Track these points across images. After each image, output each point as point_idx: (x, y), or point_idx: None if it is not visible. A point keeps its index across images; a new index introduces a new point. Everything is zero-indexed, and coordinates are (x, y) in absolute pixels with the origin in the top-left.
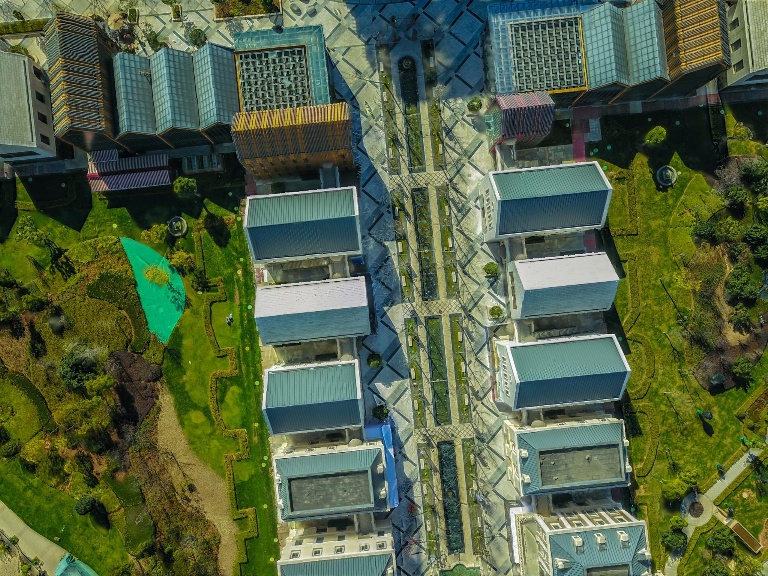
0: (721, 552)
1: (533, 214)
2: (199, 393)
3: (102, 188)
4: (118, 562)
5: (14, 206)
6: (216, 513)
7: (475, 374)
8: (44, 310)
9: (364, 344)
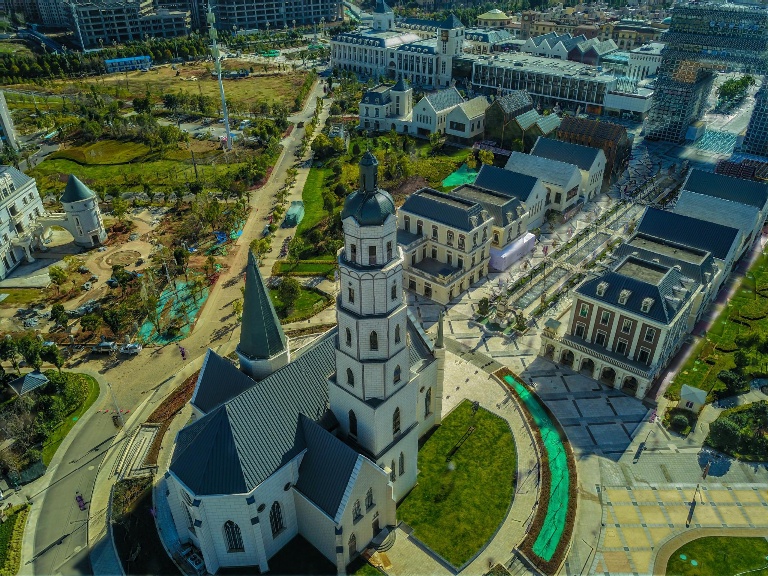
0: None
1: (712, 186)
2: None
3: None
4: (320, 216)
5: None
6: None
7: None
8: None
9: None
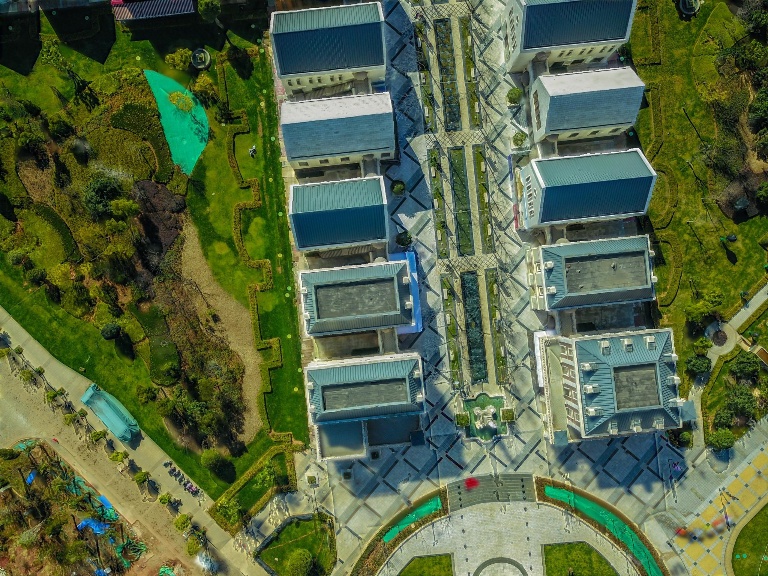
0: (745, 377)
1: (558, 24)
2: (223, 224)
3: (126, 16)
4: None
5: (38, 38)
6: (240, 343)
7: (498, 205)
8: (68, 141)
9: (387, 175)
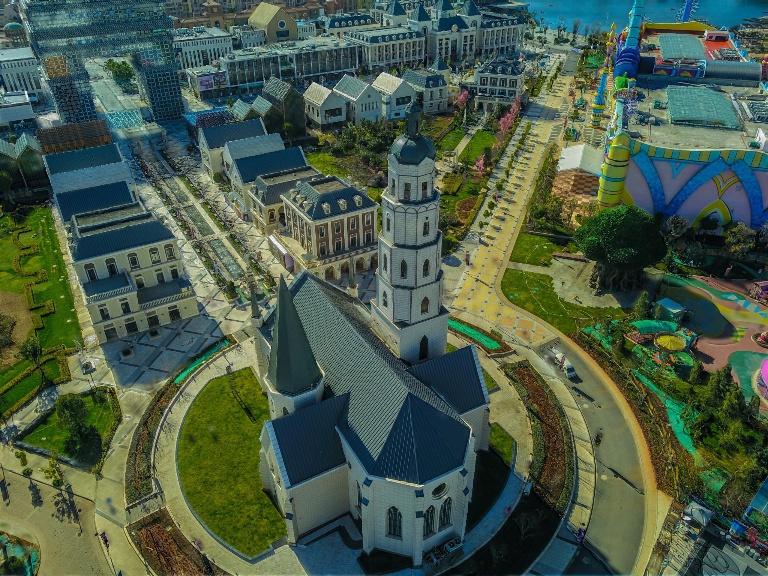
0: None
1: (224, 135)
2: (4, 265)
3: None
4: None
5: None
6: (13, 311)
7: None
8: None
9: None
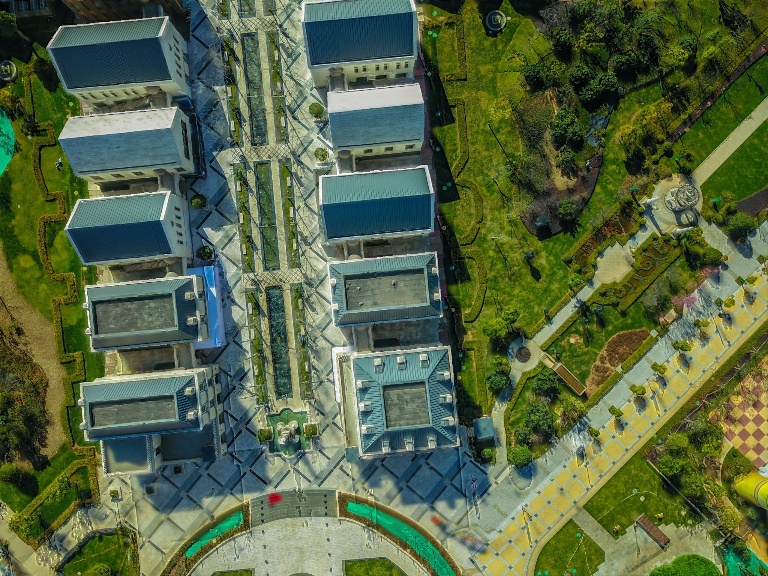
0: (544, 394)
1: (341, 40)
2: (28, 237)
3: None
4: None
5: None
6: (44, 357)
7: (304, 219)
8: None
9: (193, 189)
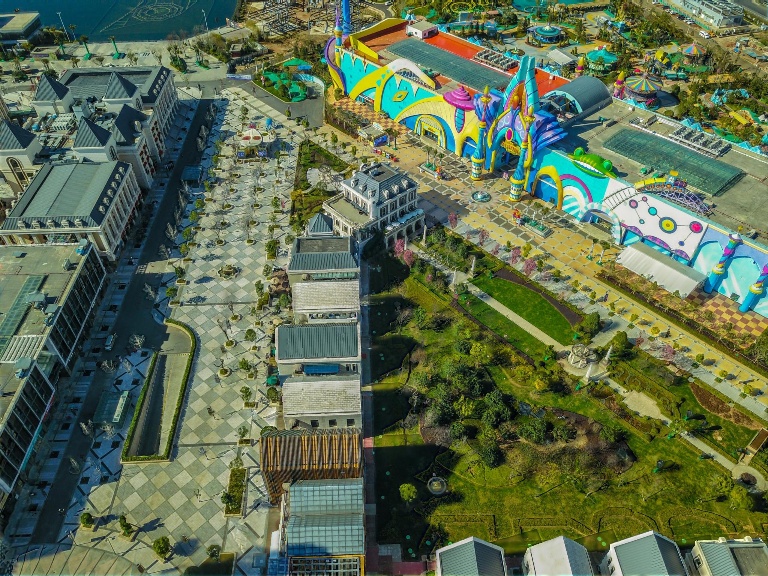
0: None
1: None
2: None
3: None
4: None
5: None
6: None
7: None
8: None
9: None
